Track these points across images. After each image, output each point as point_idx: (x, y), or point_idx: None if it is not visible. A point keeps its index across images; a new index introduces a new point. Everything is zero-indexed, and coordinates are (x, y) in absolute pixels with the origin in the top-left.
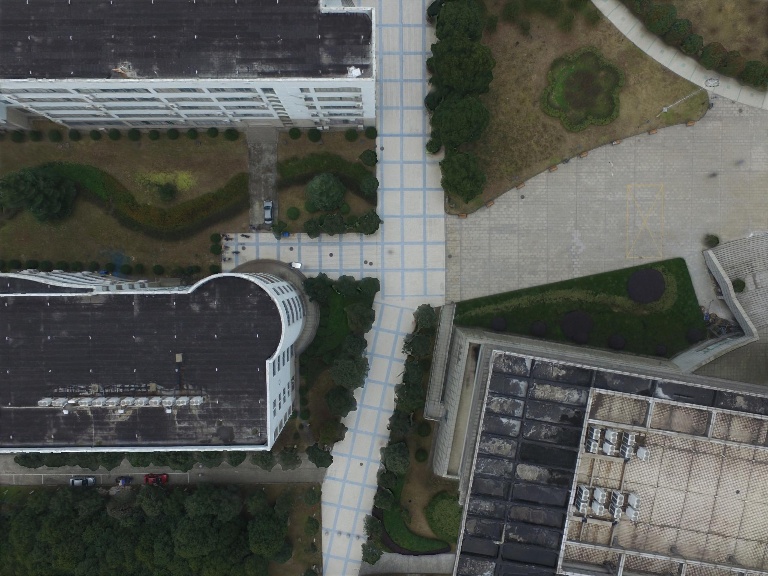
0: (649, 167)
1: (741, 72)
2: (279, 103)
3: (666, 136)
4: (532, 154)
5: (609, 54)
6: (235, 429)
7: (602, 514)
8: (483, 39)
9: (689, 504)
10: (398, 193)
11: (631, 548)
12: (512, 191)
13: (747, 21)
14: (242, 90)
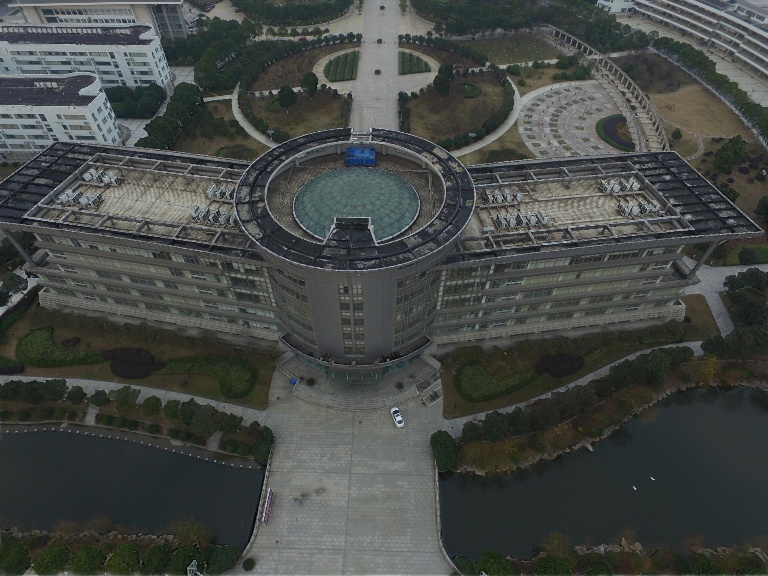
0: None
1: None
2: (53, 133)
3: None
4: None
5: (251, 147)
6: None
7: (72, 198)
8: (189, 142)
9: None
10: None
11: None
12: None
13: None
14: (31, 117)
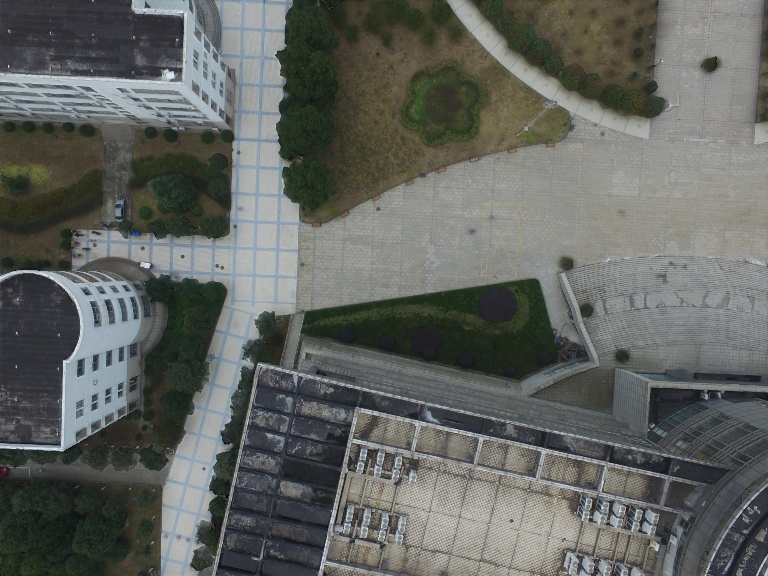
0: (507, 186)
1: (602, 95)
2: (112, 102)
3: (526, 155)
4: (389, 166)
5: (471, 70)
6: (33, 428)
7: (365, 536)
8: (345, 48)
9: (462, 531)
10: (253, 198)
11: (400, 572)
12: (368, 202)
13: (613, 44)
14: (61, 87)
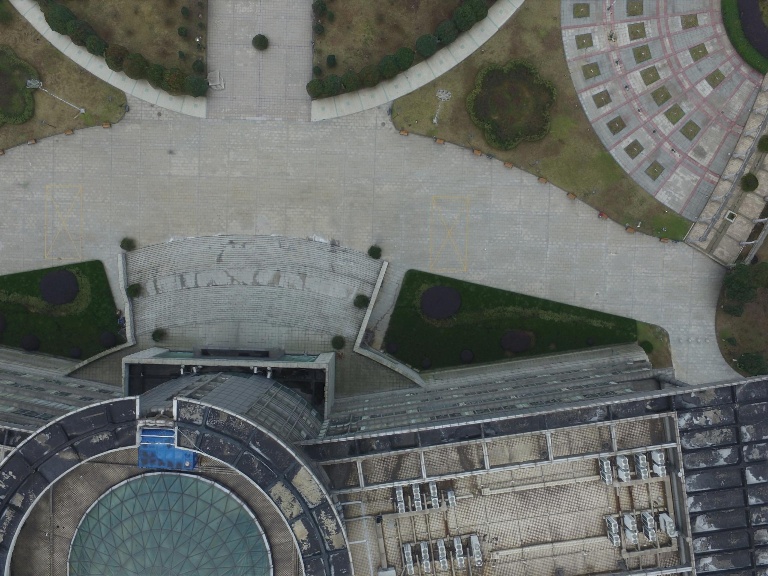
0: (67, 168)
1: None
2: None
3: (85, 137)
4: None
5: (25, 53)
6: None
7: None
8: None
9: None
10: None
11: None
12: None
13: (164, 24)
14: None
